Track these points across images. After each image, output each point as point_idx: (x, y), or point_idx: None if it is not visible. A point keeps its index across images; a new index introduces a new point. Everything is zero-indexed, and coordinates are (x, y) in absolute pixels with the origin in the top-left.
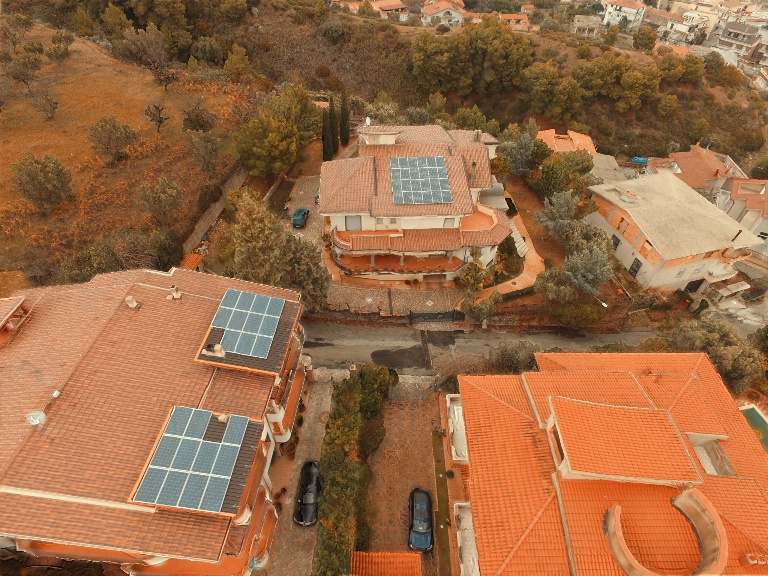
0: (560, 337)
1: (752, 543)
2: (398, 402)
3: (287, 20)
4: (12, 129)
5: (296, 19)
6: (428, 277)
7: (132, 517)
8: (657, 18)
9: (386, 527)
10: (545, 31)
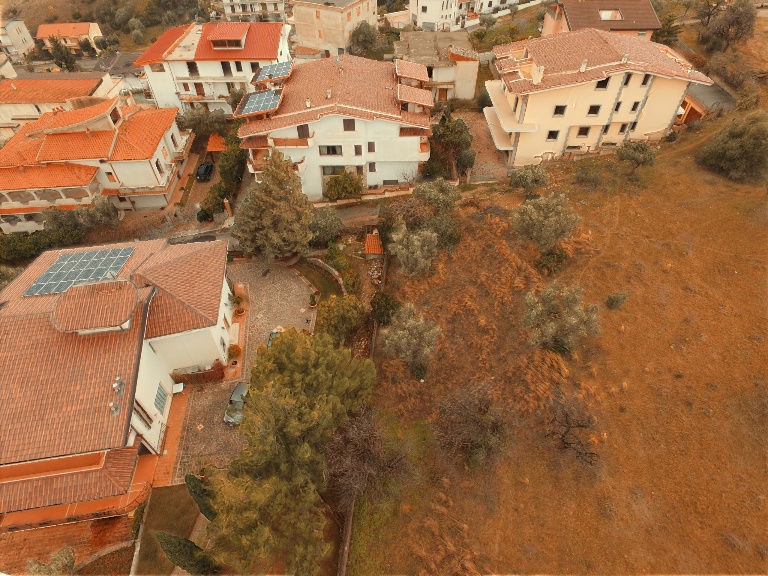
0: None
1: None
2: None
3: None
4: None
5: None
6: None
7: (297, 68)
8: None
9: None
10: None
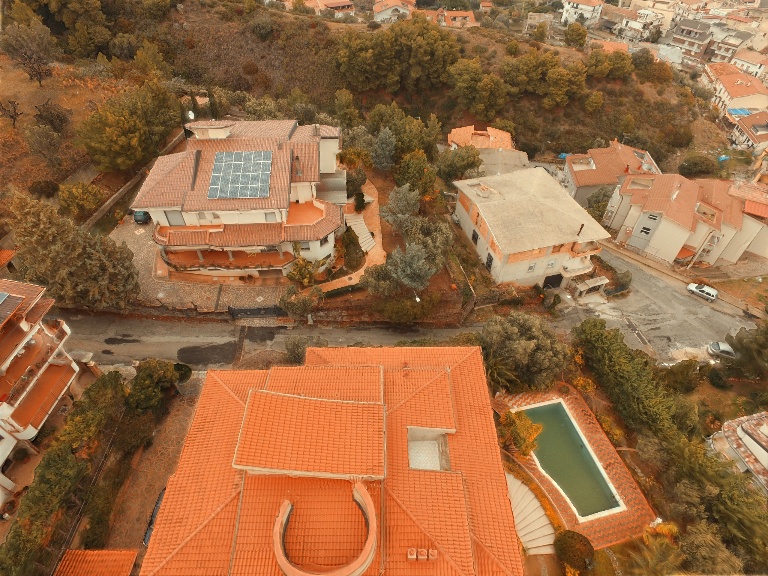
0: (391, 332)
1: (426, 537)
2: (190, 398)
3: (215, 17)
4: None
5: (224, 16)
6: (265, 273)
7: None
8: (614, 15)
9: (131, 525)
10: (475, 28)
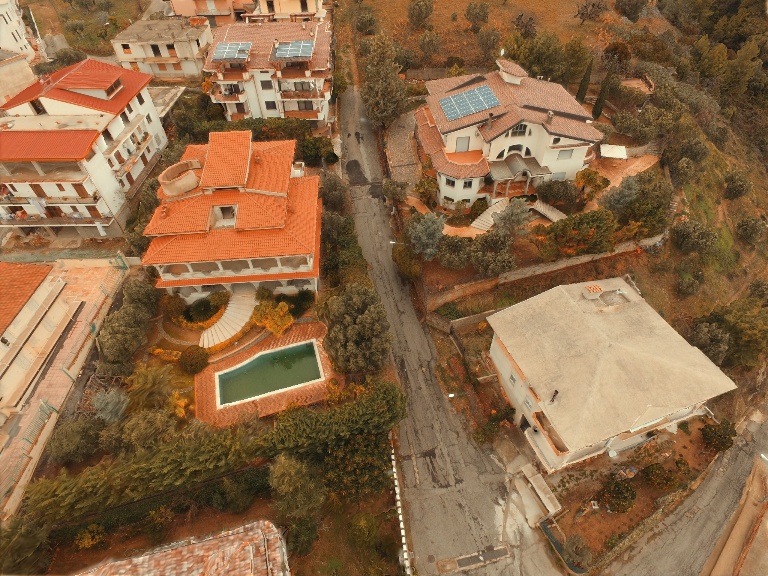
0: None
1: None
2: None
3: None
4: (485, 0)
5: None
6: None
7: None
8: None
9: None
10: None
